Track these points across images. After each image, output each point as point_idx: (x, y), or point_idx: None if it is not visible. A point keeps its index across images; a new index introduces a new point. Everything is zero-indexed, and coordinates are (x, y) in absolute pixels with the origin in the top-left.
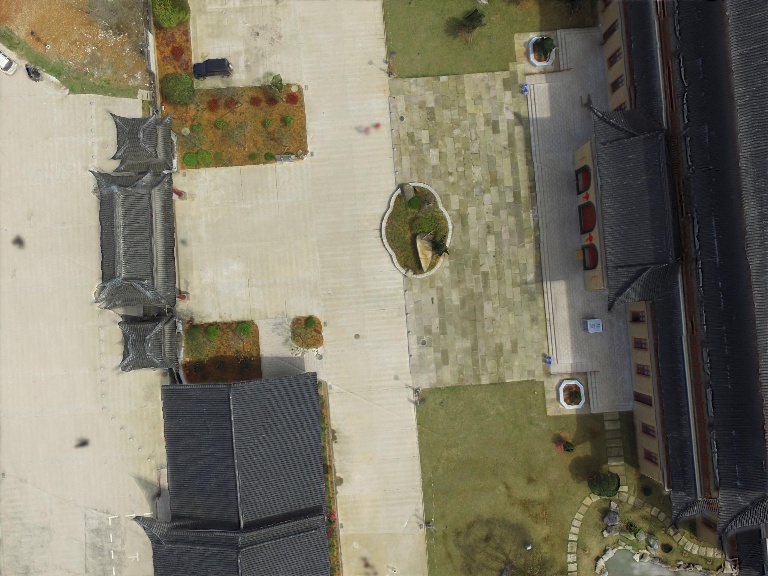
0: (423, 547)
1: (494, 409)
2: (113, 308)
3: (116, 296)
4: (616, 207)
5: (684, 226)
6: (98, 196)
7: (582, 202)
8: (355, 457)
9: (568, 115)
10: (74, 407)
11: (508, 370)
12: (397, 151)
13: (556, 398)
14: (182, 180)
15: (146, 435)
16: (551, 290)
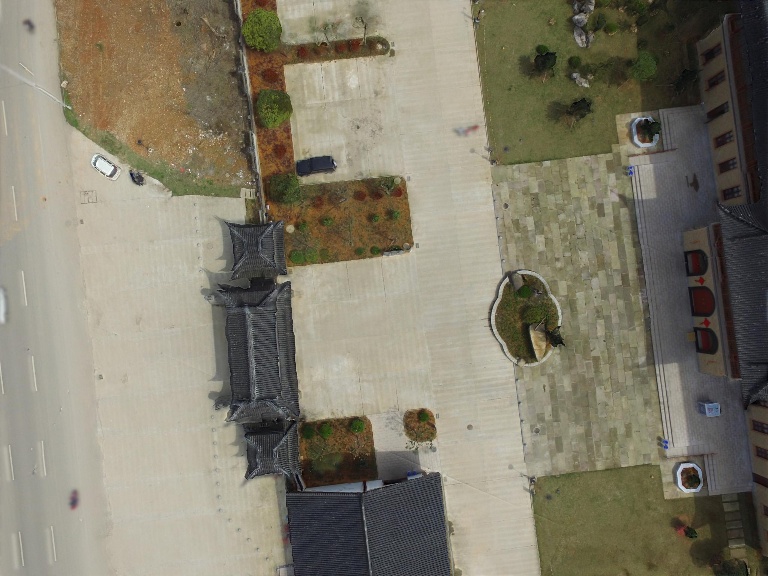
0: None
1: (611, 495)
2: (238, 419)
3: None
4: (747, 303)
5: None
6: (211, 301)
7: (694, 285)
8: (473, 548)
9: (674, 196)
10: (191, 509)
11: (623, 455)
12: (503, 239)
13: (673, 481)
14: (289, 277)
15: (264, 535)
16: (664, 373)
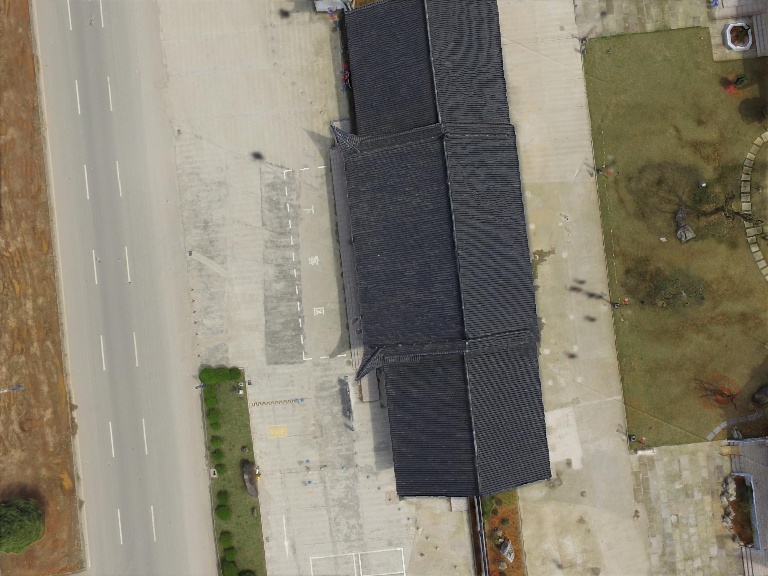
0: (595, 195)
1: (661, 55)
2: None
3: None
4: None
5: None
6: None
7: None
8: (524, 107)
9: None
10: (246, 64)
11: (673, 18)
12: None
13: (722, 44)
14: None
15: (318, 89)
16: None
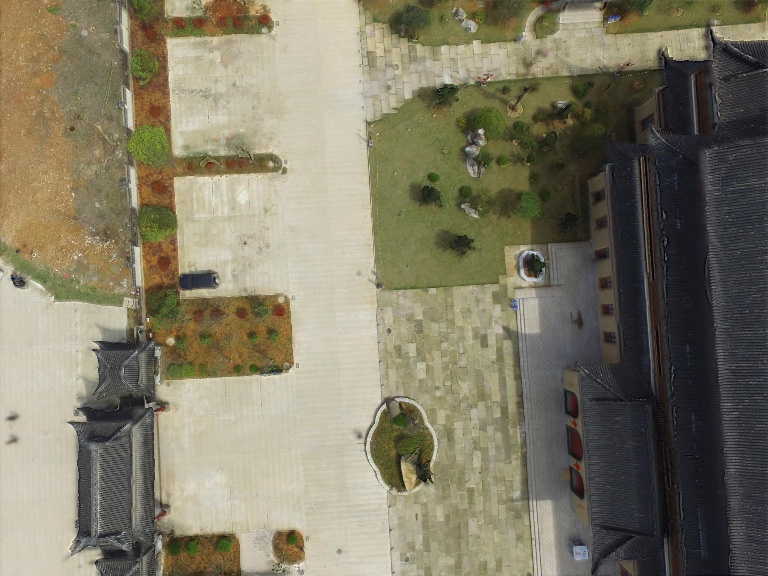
0: None
1: None
2: (91, 544)
3: None
4: (602, 465)
5: (670, 496)
6: (80, 416)
7: (570, 425)
8: None
9: (557, 331)
10: None
11: None
12: (383, 364)
13: None
14: (166, 390)
15: None
16: (537, 509)
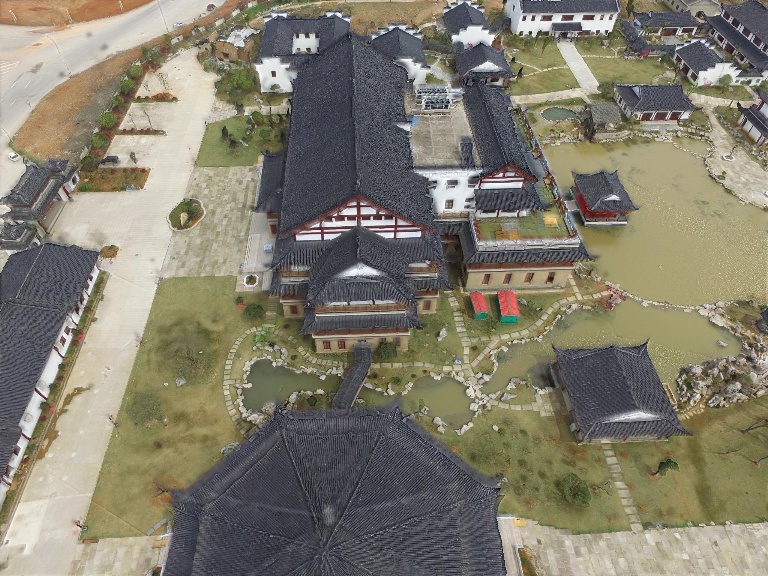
0: (134, 357)
1: (204, 287)
2: (6, 219)
3: (10, 213)
4: None
5: None
6: None
7: None
8: (110, 308)
9: None
10: None
11: (218, 271)
12: (188, 189)
13: None
14: (75, 196)
15: None
16: (252, 238)
